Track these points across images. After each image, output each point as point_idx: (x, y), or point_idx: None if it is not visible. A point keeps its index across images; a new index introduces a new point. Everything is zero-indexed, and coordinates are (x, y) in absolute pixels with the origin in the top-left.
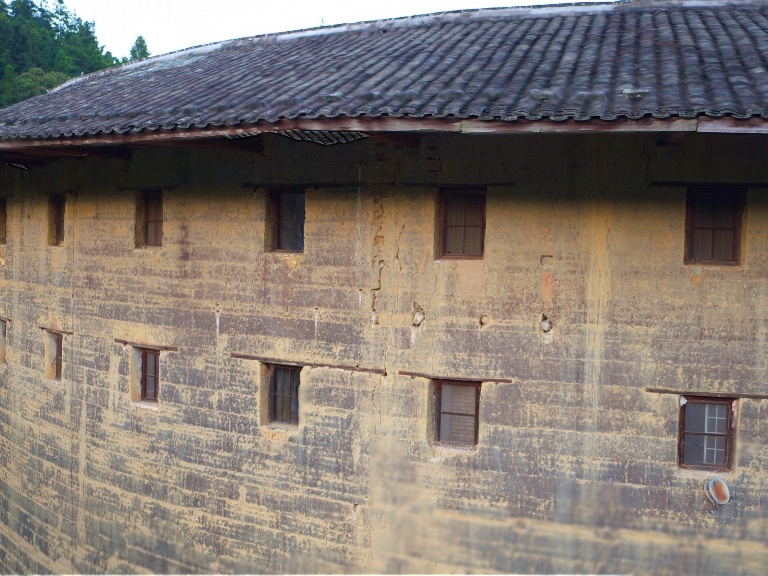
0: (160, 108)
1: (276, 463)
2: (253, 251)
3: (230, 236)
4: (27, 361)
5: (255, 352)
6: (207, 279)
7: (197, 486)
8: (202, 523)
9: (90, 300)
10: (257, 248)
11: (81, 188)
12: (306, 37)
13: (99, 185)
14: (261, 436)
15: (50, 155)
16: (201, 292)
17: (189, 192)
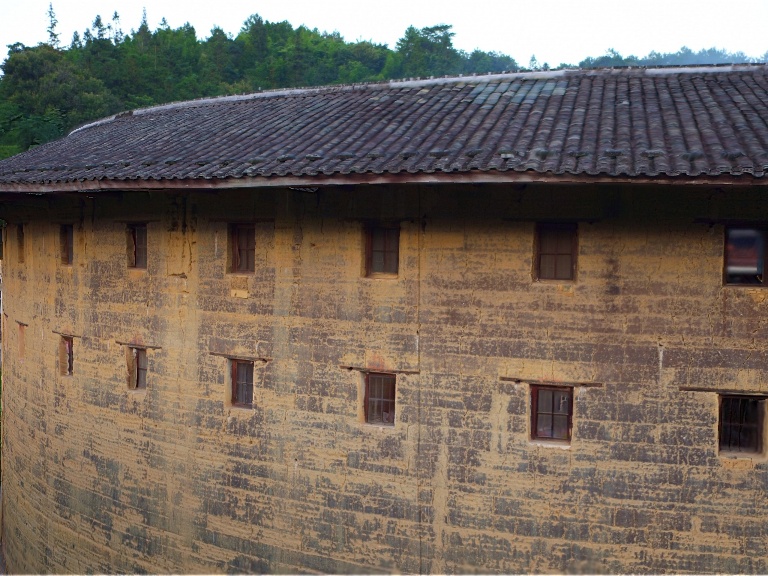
0: (740, 149)
1: (739, 491)
2: (709, 285)
3: (678, 270)
4: (313, 405)
5: (712, 384)
6: (646, 313)
7: (632, 522)
8: (641, 558)
9: (454, 337)
10: (714, 282)
11: (432, 217)
12: (687, 73)
13: (469, 215)
14: (720, 466)
15: (423, 182)
16: (637, 326)
17: (619, 226)
